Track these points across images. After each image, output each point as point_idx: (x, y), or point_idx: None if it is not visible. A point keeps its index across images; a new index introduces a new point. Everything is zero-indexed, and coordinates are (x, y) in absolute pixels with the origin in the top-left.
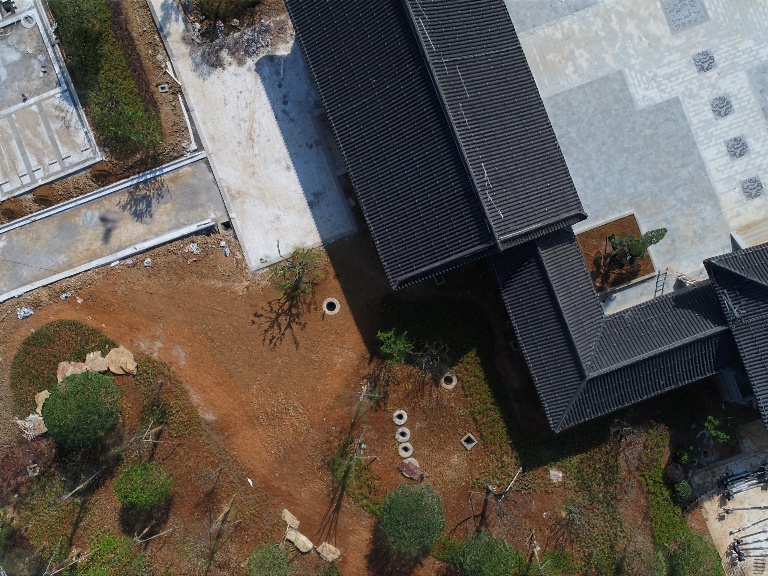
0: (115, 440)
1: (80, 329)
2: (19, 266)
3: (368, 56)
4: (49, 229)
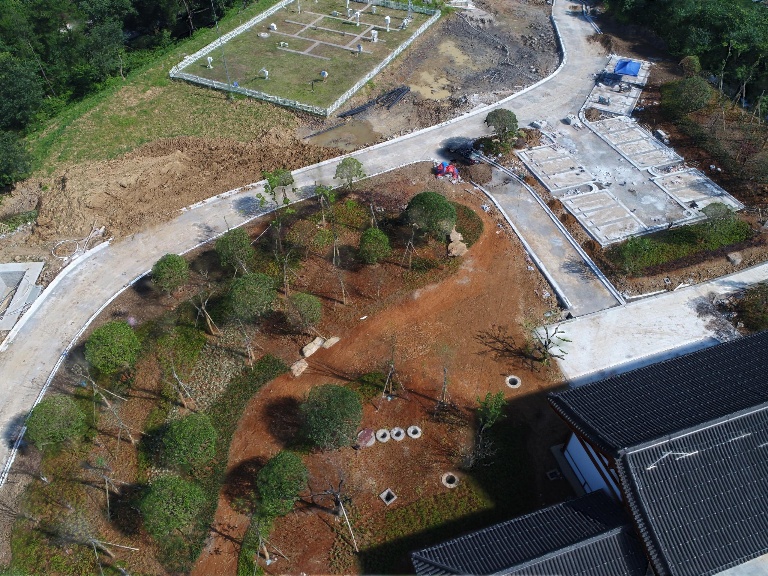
0: (400, 245)
1: (478, 231)
2: (516, 208)
3: (761, 372)
4: (544, 222)
